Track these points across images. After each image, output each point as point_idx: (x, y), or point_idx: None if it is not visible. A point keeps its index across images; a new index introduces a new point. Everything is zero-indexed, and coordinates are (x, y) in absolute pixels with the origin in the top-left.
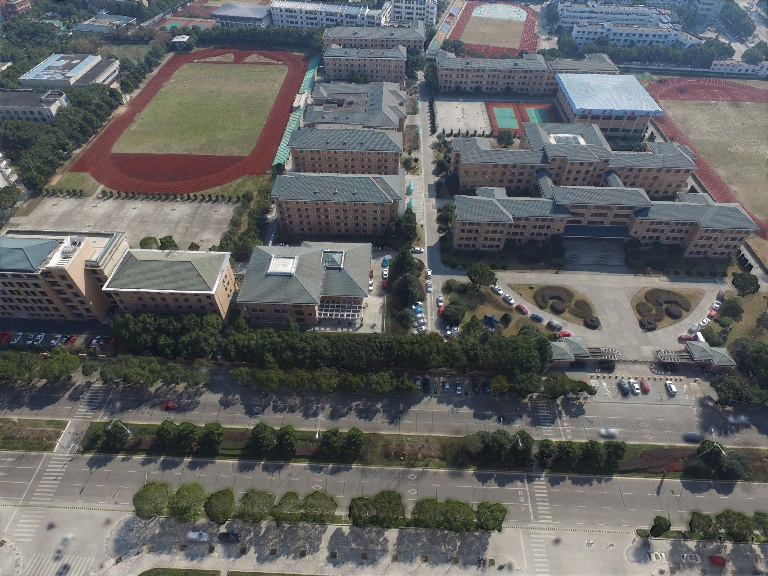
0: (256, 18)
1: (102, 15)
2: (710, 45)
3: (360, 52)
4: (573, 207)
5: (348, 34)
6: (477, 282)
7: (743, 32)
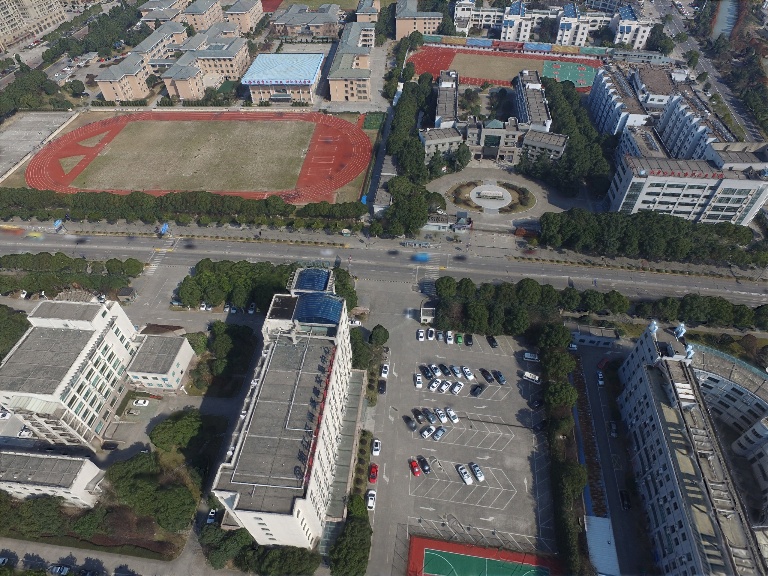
0: None
1: None
2: None
3: None
4: None
5: None
6: None
7: None
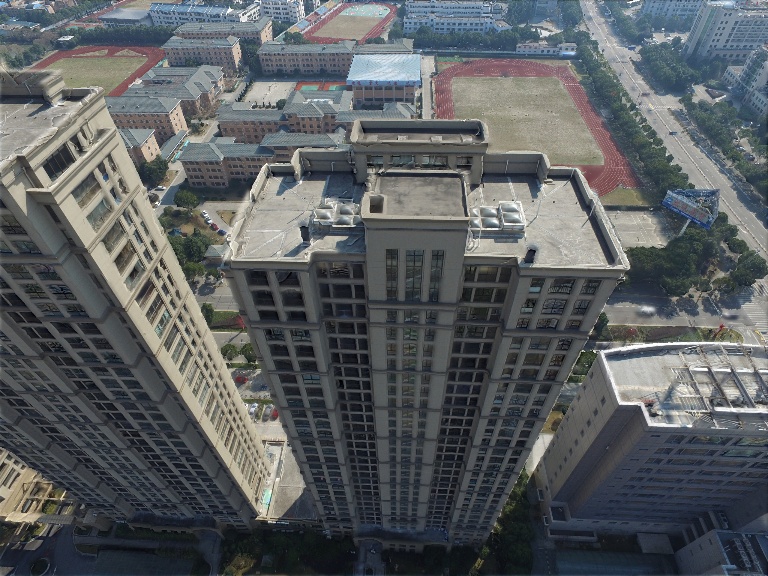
0: (134, 20)
1: (10, 22)
2: (515, 30)
3: (193, 42)
4: (276, 149)
5: (195, 29)
6: (178, 205)
7: (571, 21)
